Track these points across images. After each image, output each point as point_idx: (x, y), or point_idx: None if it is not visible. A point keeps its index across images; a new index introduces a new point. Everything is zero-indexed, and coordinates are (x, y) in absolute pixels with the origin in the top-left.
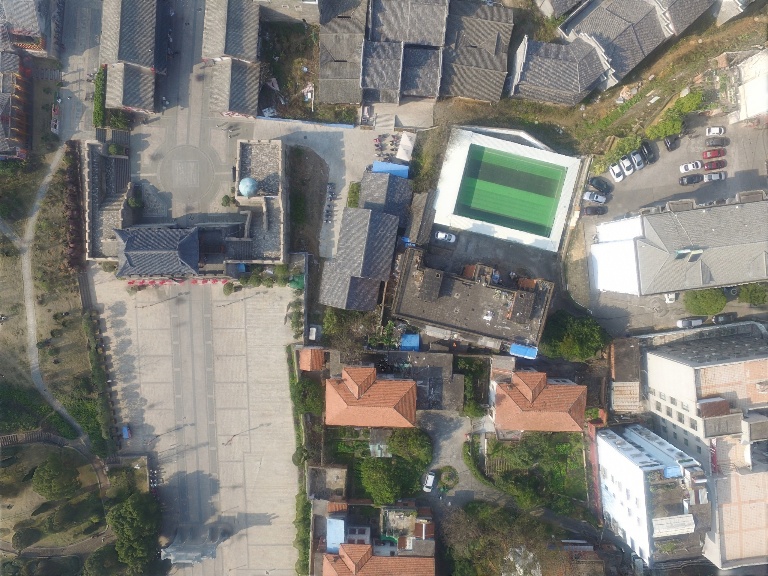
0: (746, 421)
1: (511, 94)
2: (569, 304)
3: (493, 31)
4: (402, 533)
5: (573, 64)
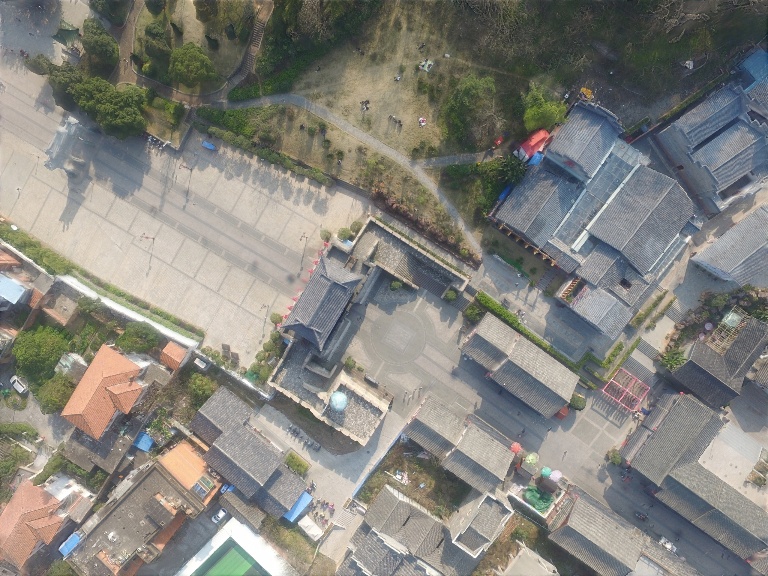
0: None
1: None
2: None
3: None
4: None
5: None
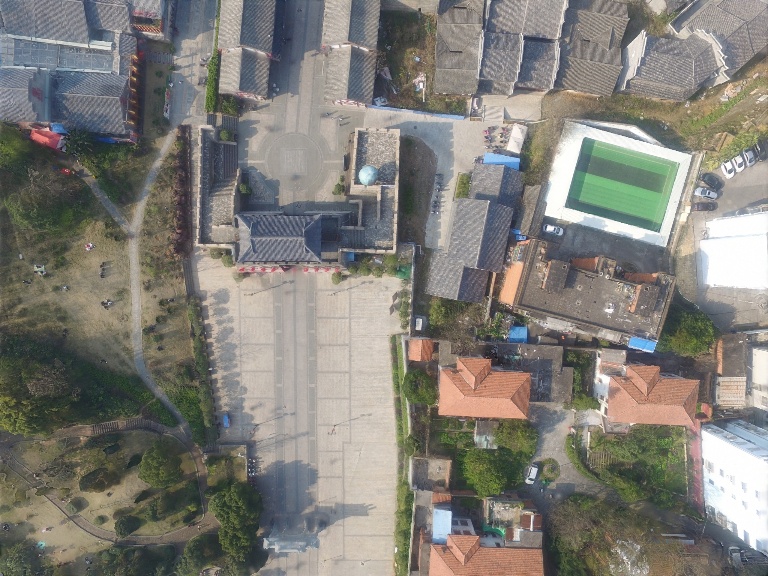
0: None
1: (622, 89)
2: (675, 299)
3: (608, 25)
4: (507, 525)
5: (689, 60)
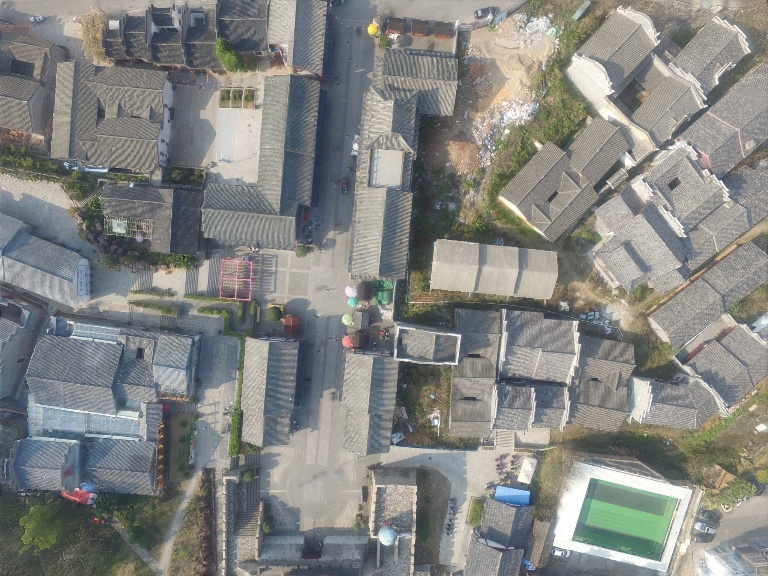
0: None
1: None
2: None
3: (615, 369)
4: None
5: (692, 410)
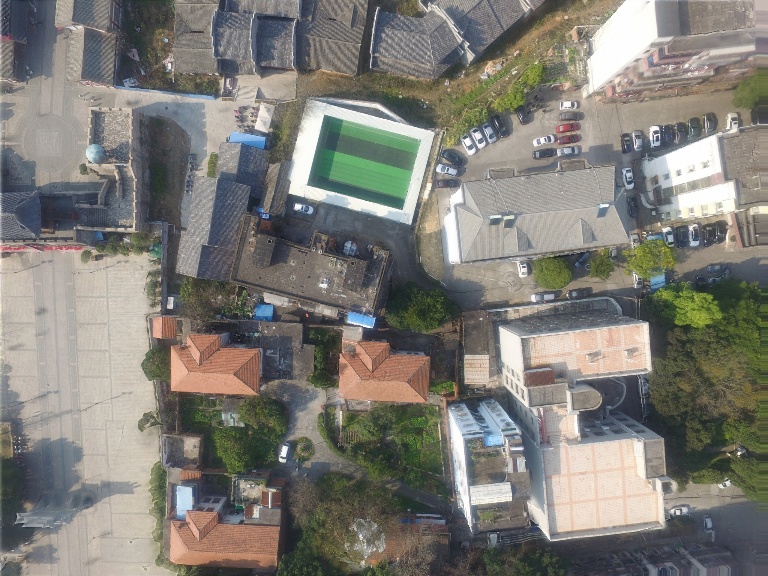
0: (569, 391)
1: None
2: (424, 277)
3: (349, 4)
4: (252, 502)
5: (424, 36)
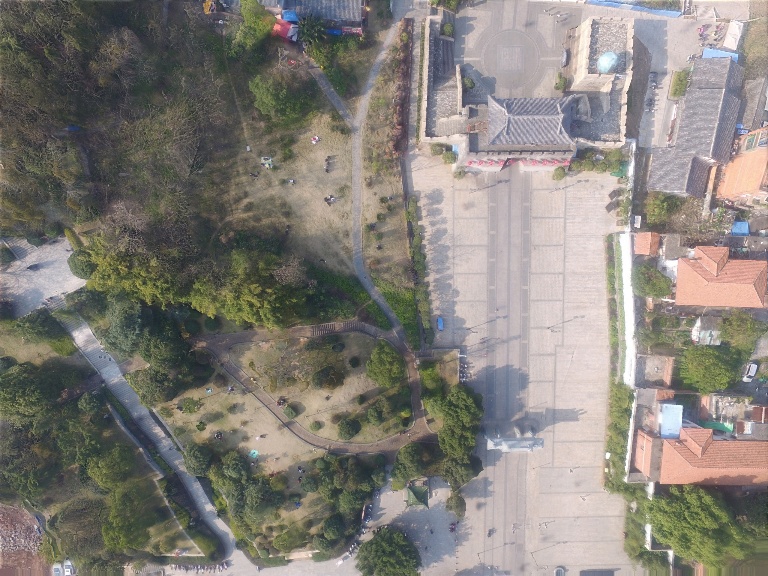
0: None
1: None
2: None
3: None
4: (733, 420)
5: None
